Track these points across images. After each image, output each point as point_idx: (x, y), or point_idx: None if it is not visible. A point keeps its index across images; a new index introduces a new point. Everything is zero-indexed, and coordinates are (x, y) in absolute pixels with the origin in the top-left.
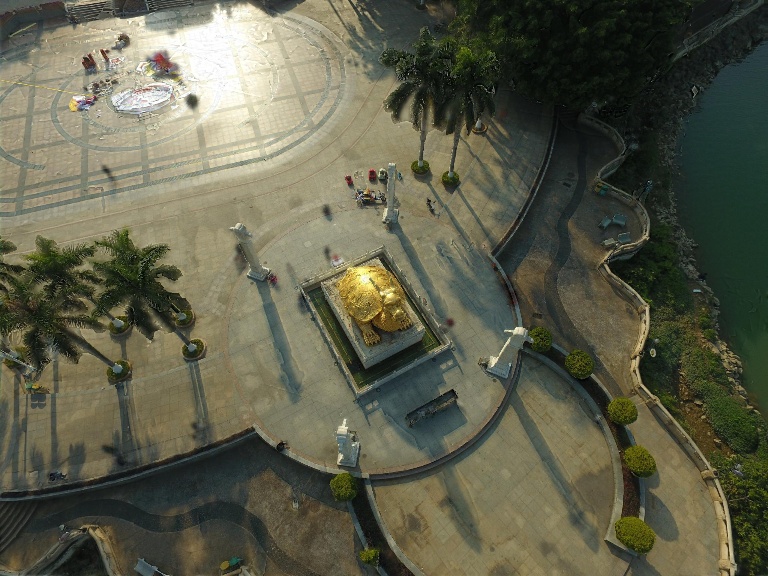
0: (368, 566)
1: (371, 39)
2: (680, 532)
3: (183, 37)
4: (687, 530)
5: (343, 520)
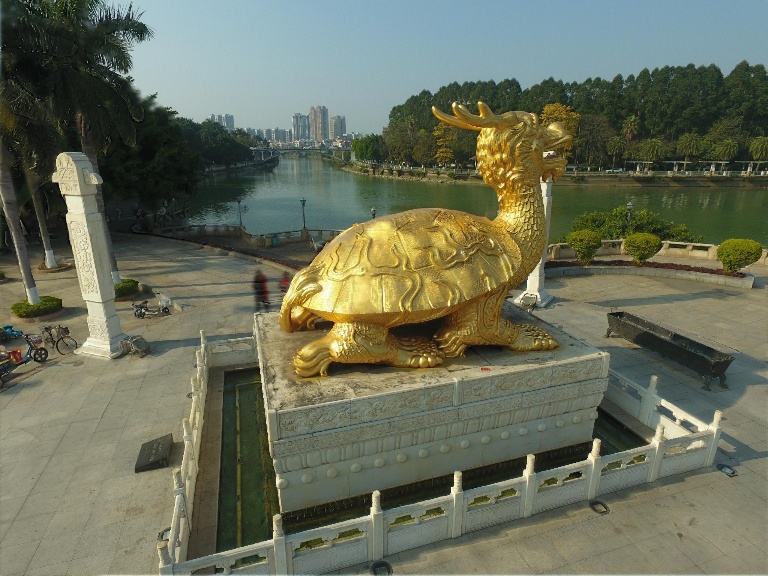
0: None
1: None
2: None
3: None
4: None
5: None
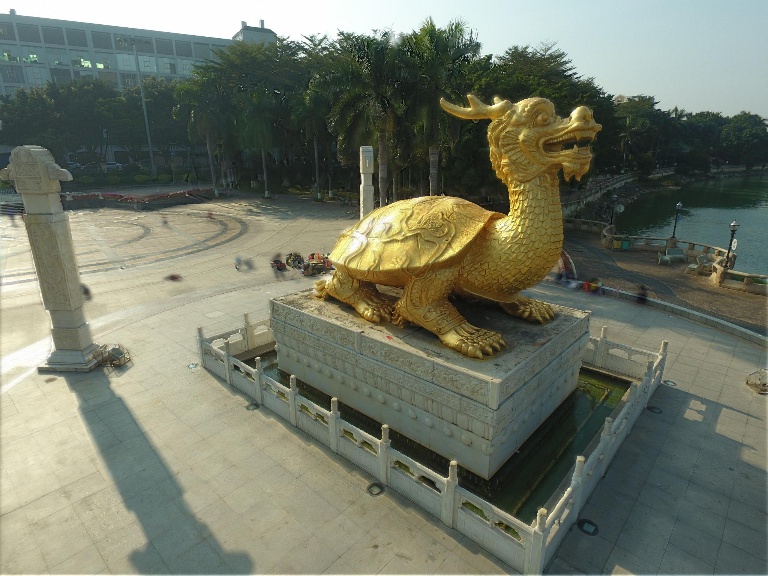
0: None
1: (272, 212)
2: None
3: (10, 224)
4: None
5: None
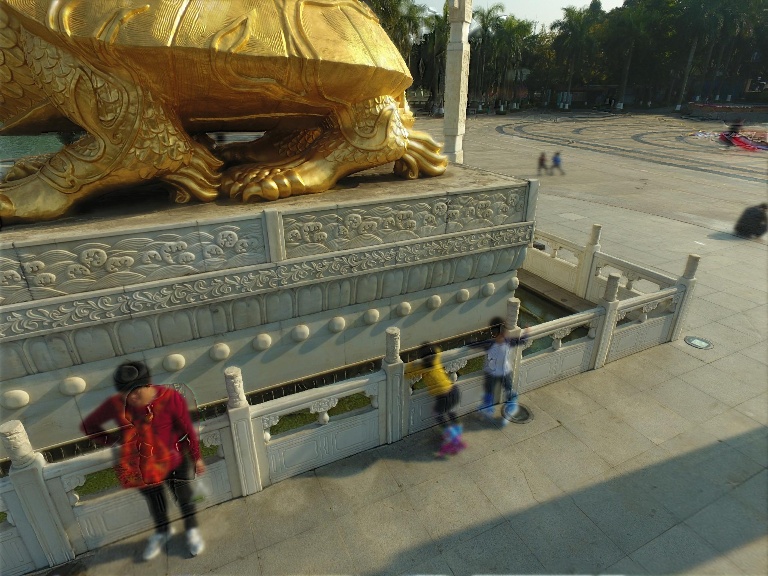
0: None
1: None
2: None
3: None
4: None
5: None
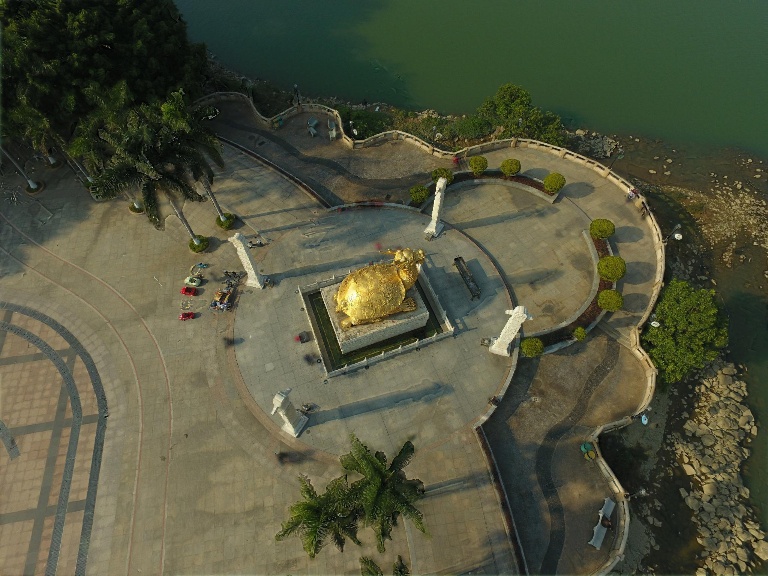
0: (577, 347)
1: None
2: (545, 168)
3: None
4: (544, 165)
5: (546, 362)
